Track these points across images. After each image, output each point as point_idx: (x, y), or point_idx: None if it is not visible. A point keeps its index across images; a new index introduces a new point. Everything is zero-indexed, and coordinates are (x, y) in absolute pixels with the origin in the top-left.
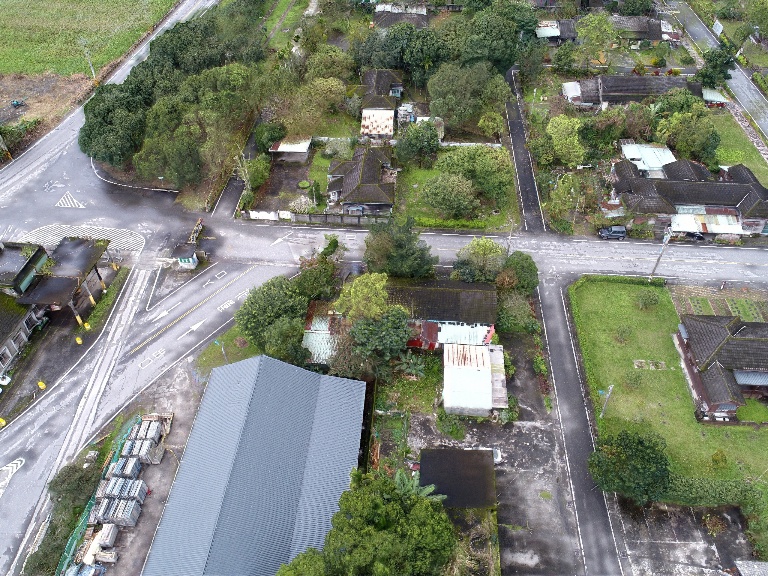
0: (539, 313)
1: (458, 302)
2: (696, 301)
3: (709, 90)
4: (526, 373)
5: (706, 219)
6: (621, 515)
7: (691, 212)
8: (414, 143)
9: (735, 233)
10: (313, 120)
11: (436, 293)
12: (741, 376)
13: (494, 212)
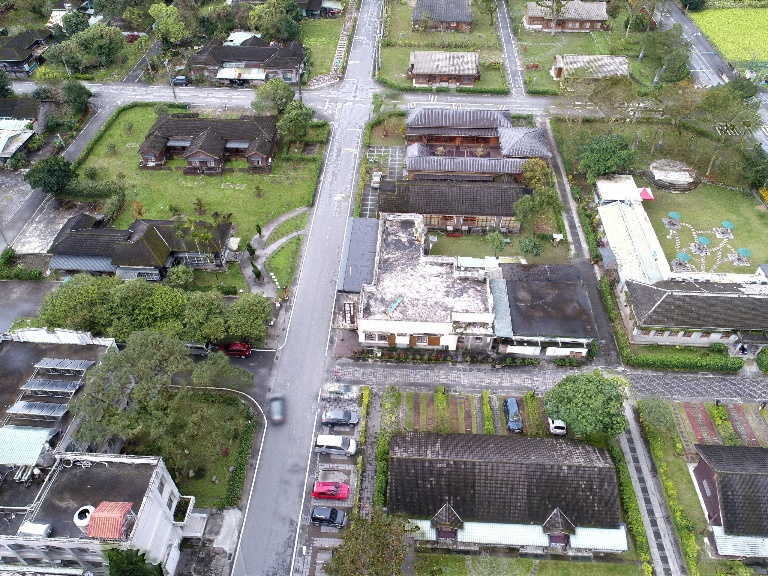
0: (88, 121)
1: (14, 106)
2: (202, 116)
3: (334, 1)
4: (50, 148)
5: (243, 71)
6: (48, 206)
7: (234, 66)
8: (66, 27)
9: (258, 79)
10: (6, 16)
11: (1, 101)
12: (173, 142)
13: (101, 69)
